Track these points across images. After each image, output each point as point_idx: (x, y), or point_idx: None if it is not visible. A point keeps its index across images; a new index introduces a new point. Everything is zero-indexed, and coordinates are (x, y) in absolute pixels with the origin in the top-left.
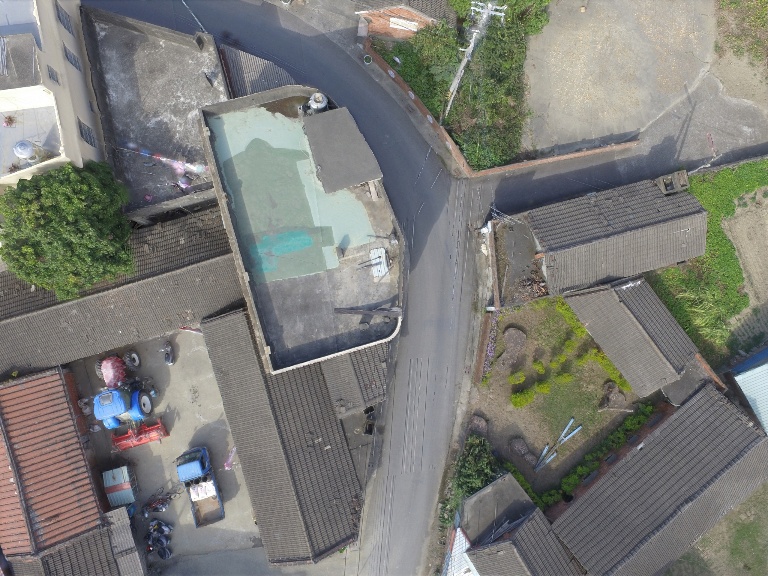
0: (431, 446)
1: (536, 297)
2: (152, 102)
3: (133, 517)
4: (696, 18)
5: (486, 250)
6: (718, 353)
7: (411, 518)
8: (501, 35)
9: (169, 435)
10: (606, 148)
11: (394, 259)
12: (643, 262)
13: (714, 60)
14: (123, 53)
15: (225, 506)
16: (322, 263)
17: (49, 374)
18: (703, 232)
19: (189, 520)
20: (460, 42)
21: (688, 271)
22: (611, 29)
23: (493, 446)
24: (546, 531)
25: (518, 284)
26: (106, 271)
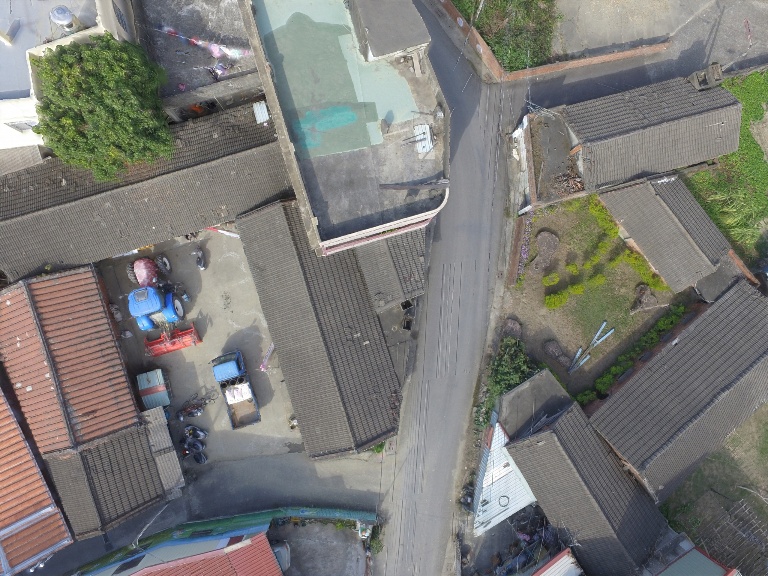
0: (465, 350)
1: (572, 192)
2: None
3: (168, 422)
4: None
5: (517, 155)
6: (747, 256)
7: (446, 422)
8: None
9: (202, 341)
10: (637, 50)
11: (438, 135)
12: (678, 157)
13: None
14: None
15: (260, 412)
16: (366, 139)
17: (82, 271)
18: (737, 126)
19: (224, 426)
20: None
21: (718, 175)
22: None
23: (527, 350)
24: (584, 424)
25: (554, 180)
26: (146, 147)
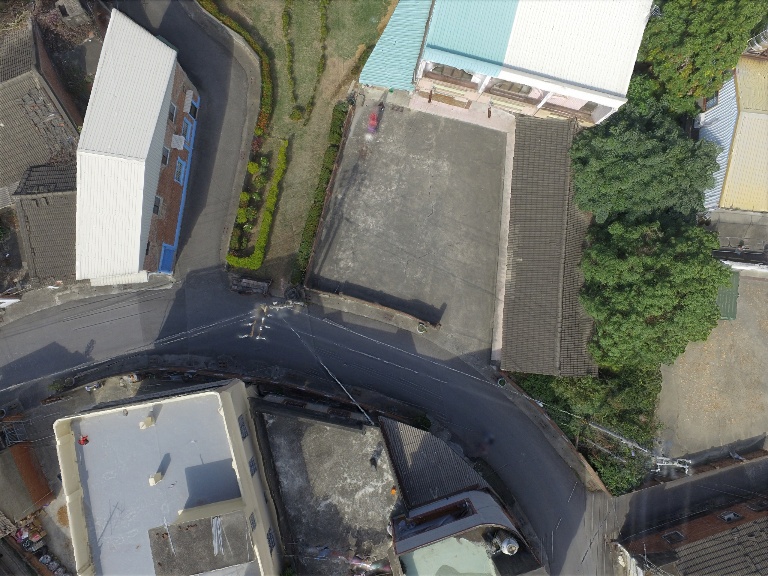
0: None
1: None
2: (321, 486)
3: None
4: None
5: (623, 561)
6: None
7: None
8: (642, 382)
9: None
10: None
11: None
12: None
13: None
14: (291, 439)
15: None
16: None
17: None
18: None
19: None
20: None
21: None
22: (734, 337)
23: None
24: None
25: None
26: None
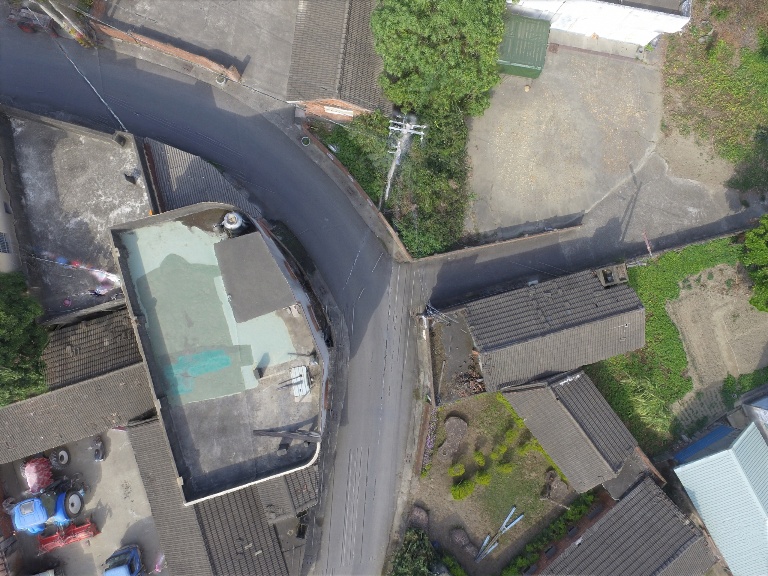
0: (371, 537)
1: (473, 394)
2: (71, 201)
3: None
4: (642, 96)
5: None
6: (661, 439)
7: None
8: (438, 124)
9: (101, 532)
10: (549, 233)
11: (316, 377)
12: (581, 357)
13: (660, 139)
14: (40, 150)
15: None
16: (240, 383)
17: None
18: (642, 327)
19: None
20: None
21: (631, 356)
22: (555, 108)
23: (434, 537)
24: None
25: (455, 380)
26: (14, 395)
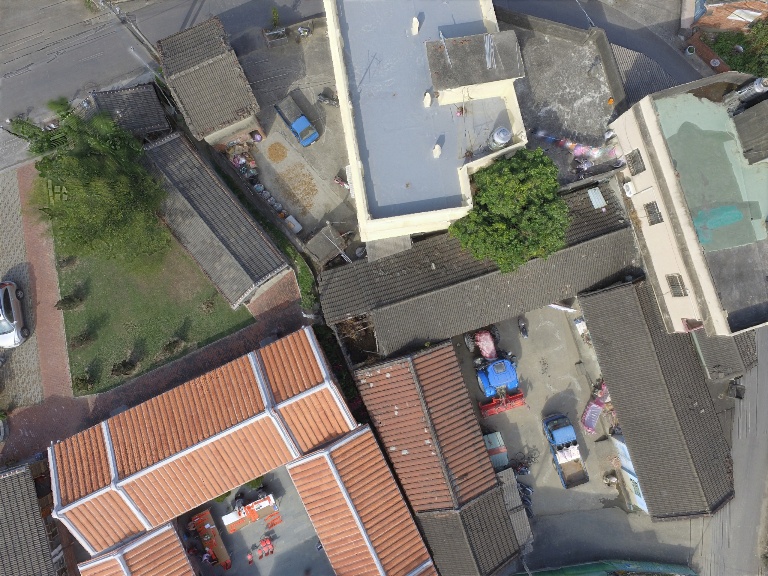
0: (764, 412)
1: None
2: (541, 93)
3: None
4: None
5: None
6: None
7: (749, 480)
8: None
9: None
10: None
11: None
12: None
13: None
14: None
15: None
16: (752, 235)
17: (446, 345)
18: None
19: (545, 483)
20: None
21: None
22: None
23: None
24: None
25: None
26: None
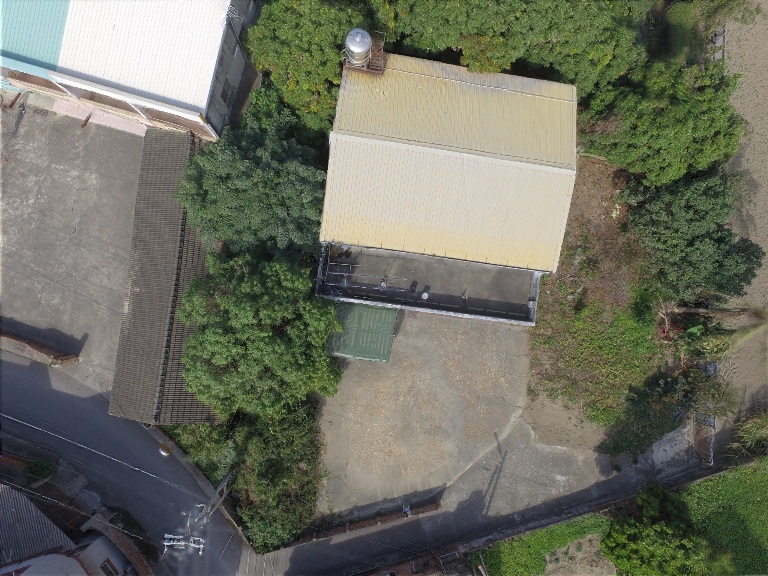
0: None
1: None
2: None
3: None
4: (507, 360)
5: None
6: None
7: None
8: (273, 430)
9: None
10: None
11: None
12: None
13: (526, 404)
14: None
15: None
16: None
17: None
18: None
19: None
20: (236, 425)
21: None
22: (415, 378)
23: None
24: None
25: None
26: None
